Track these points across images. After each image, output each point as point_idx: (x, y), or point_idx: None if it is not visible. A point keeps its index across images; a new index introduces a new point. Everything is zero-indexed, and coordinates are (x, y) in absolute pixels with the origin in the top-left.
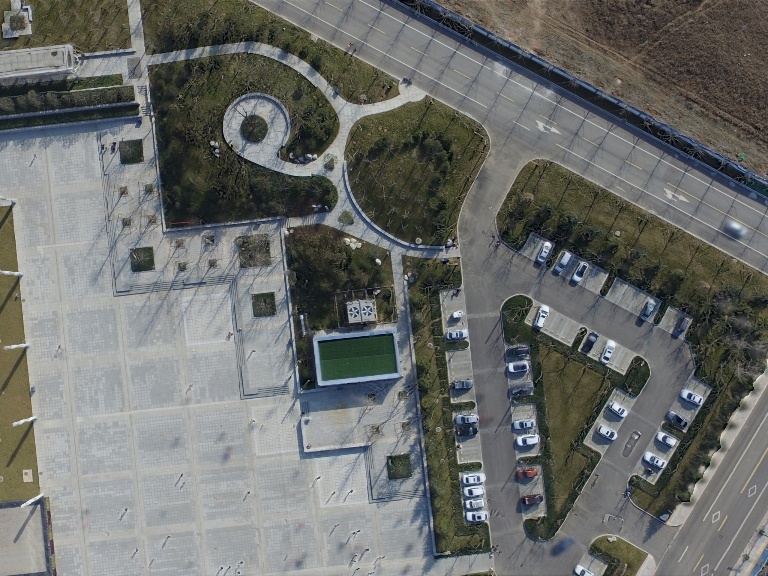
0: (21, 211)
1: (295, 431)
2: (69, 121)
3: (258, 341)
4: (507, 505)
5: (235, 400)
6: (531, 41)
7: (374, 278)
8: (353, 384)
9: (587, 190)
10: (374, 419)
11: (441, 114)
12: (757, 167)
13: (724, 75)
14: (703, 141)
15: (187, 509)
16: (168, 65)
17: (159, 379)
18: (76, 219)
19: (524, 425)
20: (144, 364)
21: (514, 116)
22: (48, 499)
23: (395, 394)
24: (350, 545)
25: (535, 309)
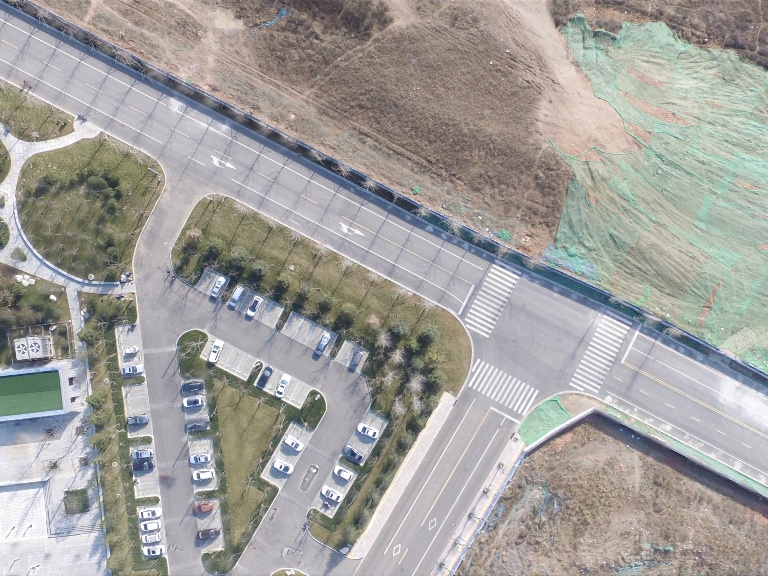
0: None
1: None
2: None
3: None
4: (186, 539)
5: None
6: (205, 77)
7: (48, 314)
8: (27, 420)
9: (261, 225)
10: (52, 454)
11: (114, 150)
12: (432, 200)
13: (395, 109)
14: (377, 175)
15: None
16: None
17: None
18: None
19: (198, 460)
20: None
21: (189, 151)
22: None
23: (73, 429)
24: None
25: (210, 344)
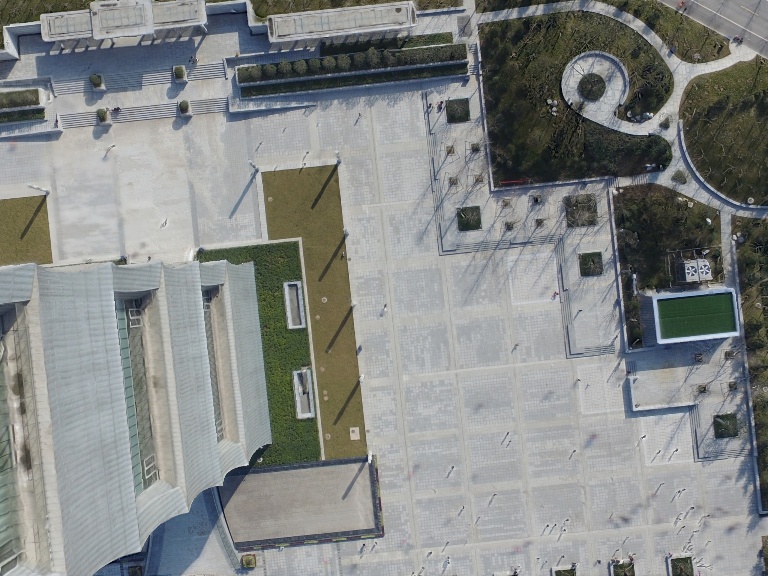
0: (346, 170)
1: (620, 390)
2: (398, 79)
3: (585, 300)
4: None
5: (560, 359)
6: None
7: (705, 238)
8: (683, 343)
9: None
10: (701, 378)
11: None
12: None
13: None
14: None
15: (513, 467)
16: (500, 23)
17: (485, 338)
18: (401, 178)
19: None
20: (470, 323)
21: None
22: (376, 457)
23: (722, 354)
24: (675, 503)
25: None
